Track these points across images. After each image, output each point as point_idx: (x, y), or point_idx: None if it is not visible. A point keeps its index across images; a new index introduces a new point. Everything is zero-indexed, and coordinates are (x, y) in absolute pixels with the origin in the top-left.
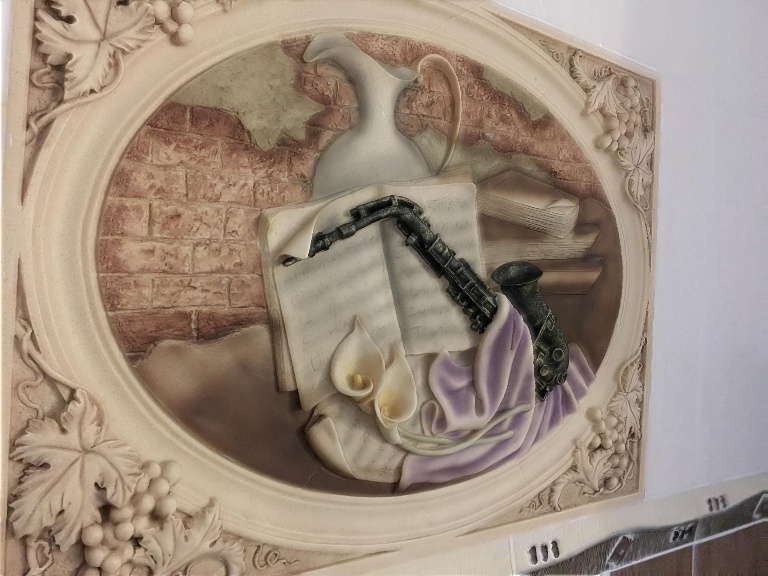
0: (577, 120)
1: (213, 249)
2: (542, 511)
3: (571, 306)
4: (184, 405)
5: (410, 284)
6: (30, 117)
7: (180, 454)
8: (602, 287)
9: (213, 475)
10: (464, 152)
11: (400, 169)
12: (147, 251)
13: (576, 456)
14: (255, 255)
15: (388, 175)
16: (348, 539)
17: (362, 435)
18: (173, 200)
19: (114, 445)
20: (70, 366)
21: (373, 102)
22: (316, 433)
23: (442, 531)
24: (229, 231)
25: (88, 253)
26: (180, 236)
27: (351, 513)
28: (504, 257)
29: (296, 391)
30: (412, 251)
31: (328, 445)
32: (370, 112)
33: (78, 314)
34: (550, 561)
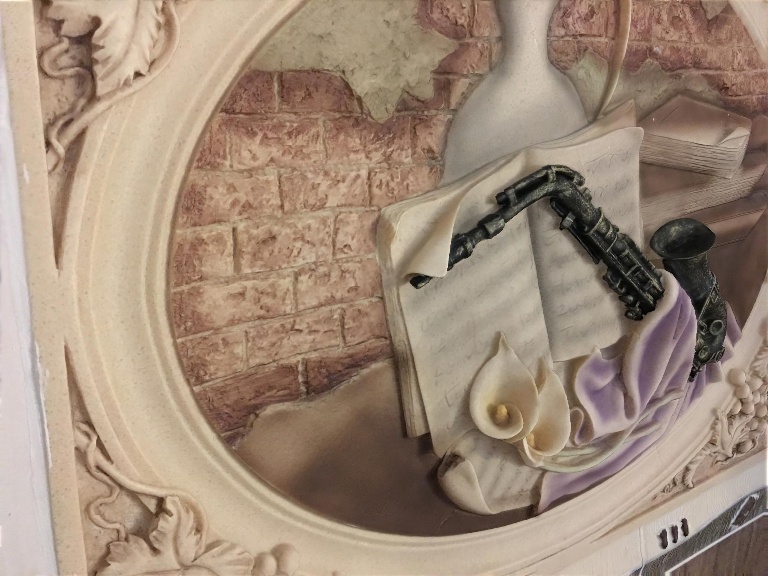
0: (757, 9)
1: (320, 275)
2: (675, 491)
3: (727, 257)
4: (297, 480)
5: (561, 277)
6: (48, 128)
7: (295, 532)
8: (760, 226)
9: (334, 545)
10: (627, 80)
11: (554, 122)
12: (235, 294)
13: (716, 429)
14: (374, 273)
15: (539, 133)
16: (482, 575)
17: (499, 463)
18: (264, 217)
19: (219, 551)
20: (152, 468)
21: (522, 27)
22: (452, 479)
23: (577, 541)
24: (340, 247)
25: (158, 314)
26: (277, 266)
27: (484, 545)
28: (663, 214)
29: (428, 435)
30: (566, 234)
31: (466, 491)
32: (518, 43)
33: (153, 396)
34: (679, 541)
